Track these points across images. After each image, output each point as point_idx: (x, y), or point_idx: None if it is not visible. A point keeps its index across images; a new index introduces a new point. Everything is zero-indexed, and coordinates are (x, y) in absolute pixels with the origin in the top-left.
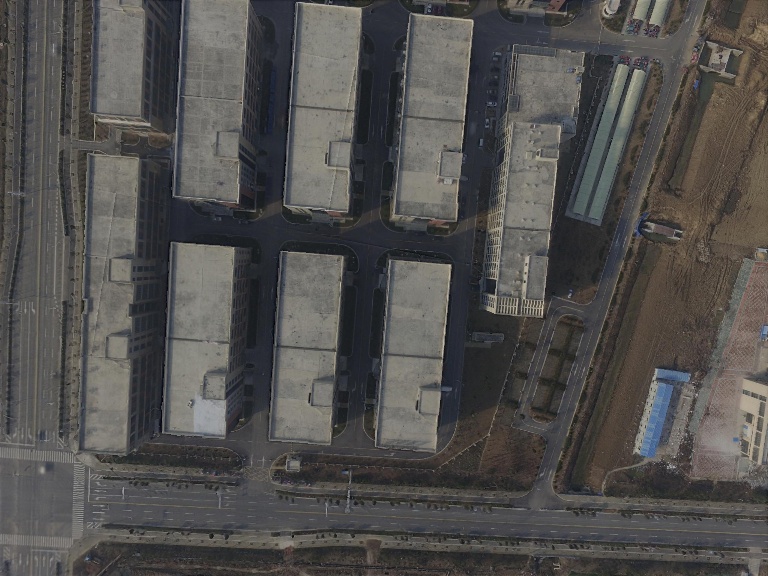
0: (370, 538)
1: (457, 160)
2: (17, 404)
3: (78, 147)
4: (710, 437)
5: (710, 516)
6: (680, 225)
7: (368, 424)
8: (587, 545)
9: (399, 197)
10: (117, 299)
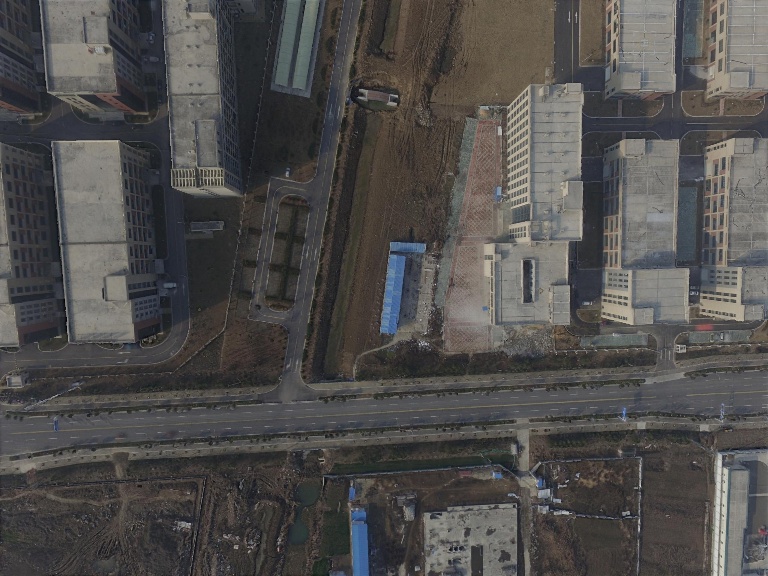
0: (116, 451)
1: (102, 25)
2: None
3: None
4: (458, 309)
5: (470, 390)
6: (398, 90)
7: None
8: (344, 433)
9: (52, 73)
10: None
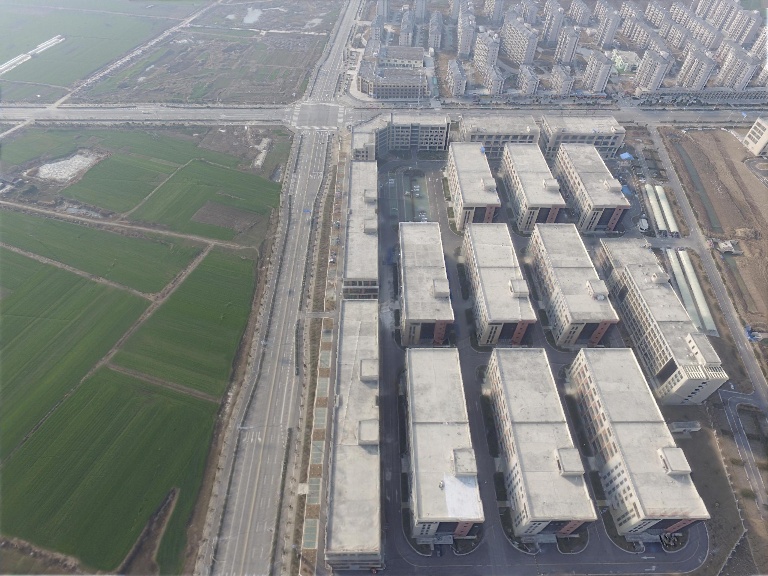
0: None
1: (601, 284)
2: (226, 542)
3: (311, 317)
4: None
5: None
6: None
7: (611, 530)
8: None
9: (569, 310)
10: (364, 394)
